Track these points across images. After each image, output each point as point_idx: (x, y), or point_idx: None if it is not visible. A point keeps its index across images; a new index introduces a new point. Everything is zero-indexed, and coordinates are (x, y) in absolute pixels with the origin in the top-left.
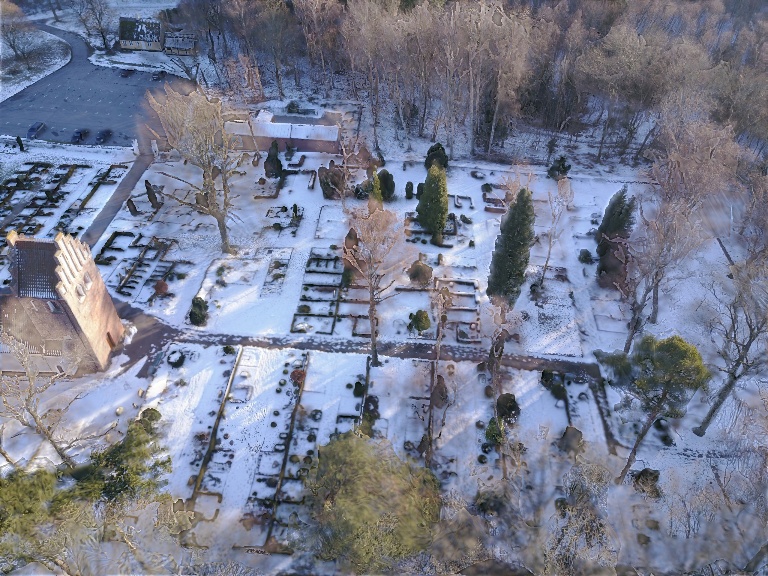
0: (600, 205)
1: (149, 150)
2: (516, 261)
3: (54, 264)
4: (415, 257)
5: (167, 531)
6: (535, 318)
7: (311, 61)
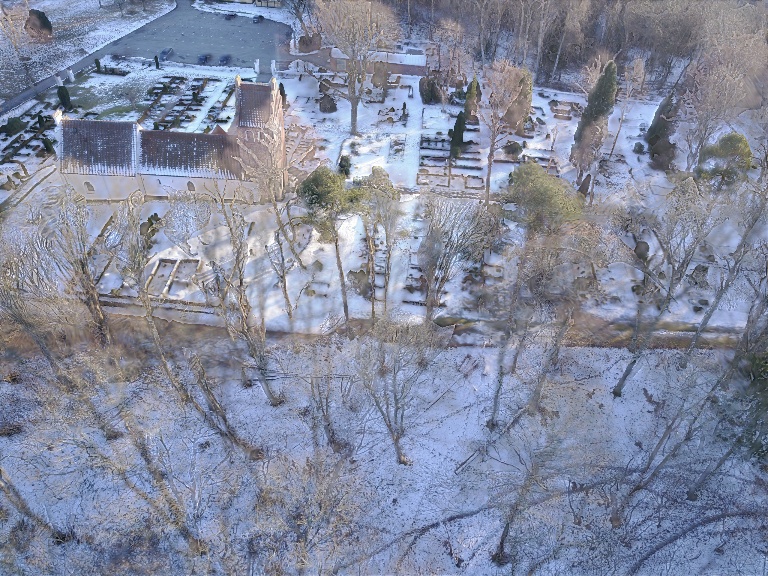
0: (646, 119)
1: (268, 69)
2: (599, 125)
3: (267, 102)
4: (505, 143)
5: (353, 291)
6: (604, 184)
7: (396, 7)
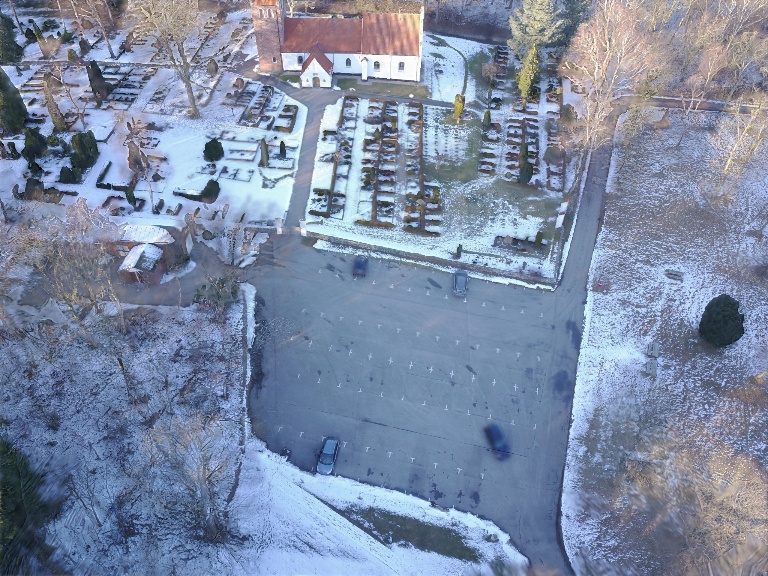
0: None
1: (289, 230)
2: None
3: None
4: None
5: None
6: None
7: None
